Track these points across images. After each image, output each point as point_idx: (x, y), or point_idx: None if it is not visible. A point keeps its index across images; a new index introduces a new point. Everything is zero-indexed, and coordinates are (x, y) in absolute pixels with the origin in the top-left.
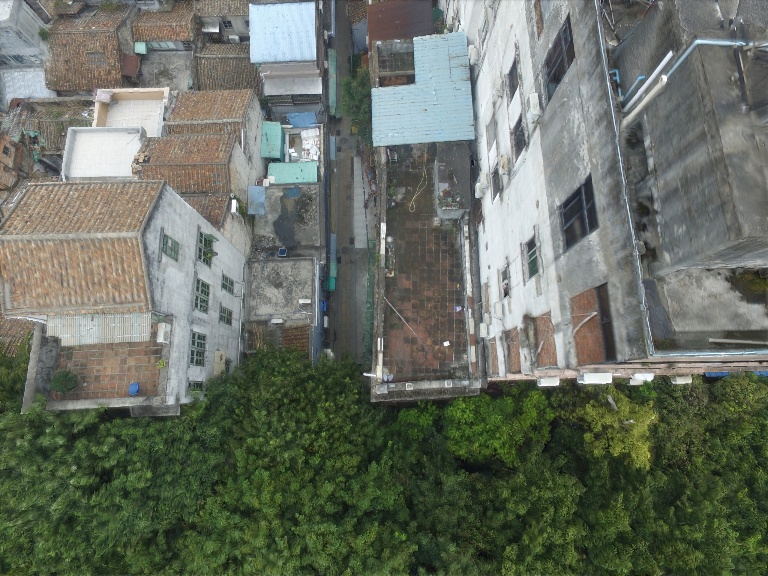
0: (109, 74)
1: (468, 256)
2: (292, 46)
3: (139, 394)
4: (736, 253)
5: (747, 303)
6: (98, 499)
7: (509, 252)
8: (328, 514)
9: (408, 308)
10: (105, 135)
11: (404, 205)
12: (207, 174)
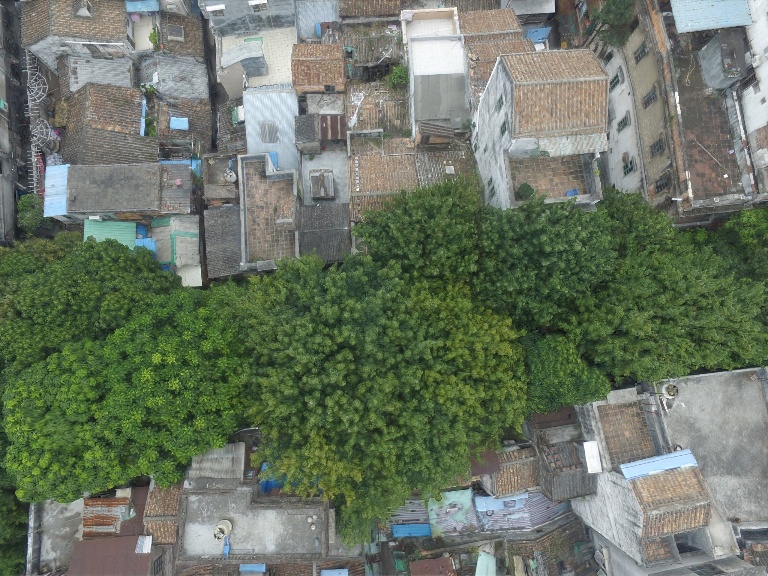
0: (390, 1)
1: (739, 113)
2: None
3: None
4: None
5: None
6: None
7: None
8: None
9: (696, 153)
10: (433, 43)
11: (682, 81)
12: None
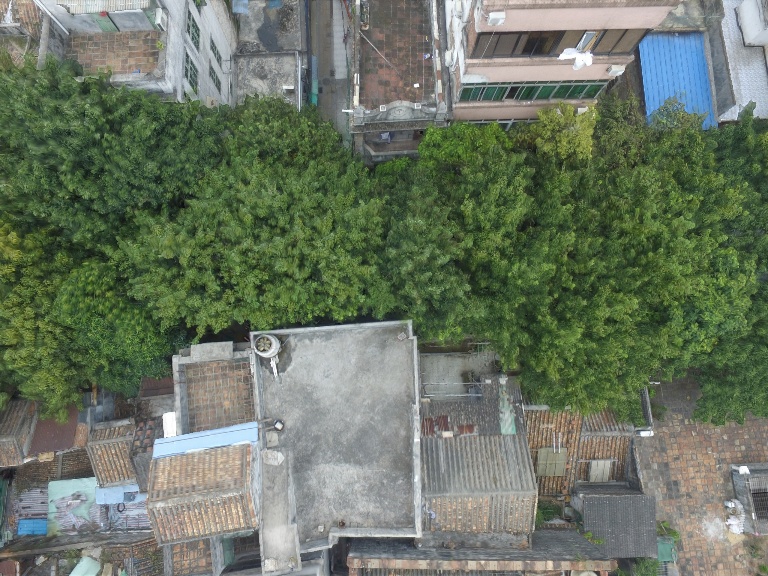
0: None
1: (435, 6)
2: None
3: None
4: None
5: None
6: (109, 139)
7: None
8: None
9: None
10: None
11: None
12: None
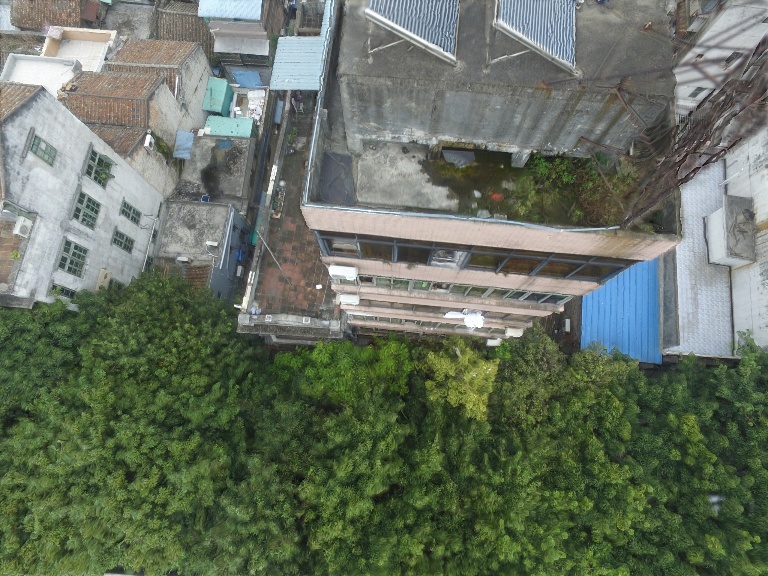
0: (69, 16)
1: None
2: (239, 5)
3: None
4: (368, 107)
5: (432, 184)
6: None
7: None
8: (164, 425)
9: (288, 249)
10: (43, 64)
11: (302, 153)
12: (127, 108)
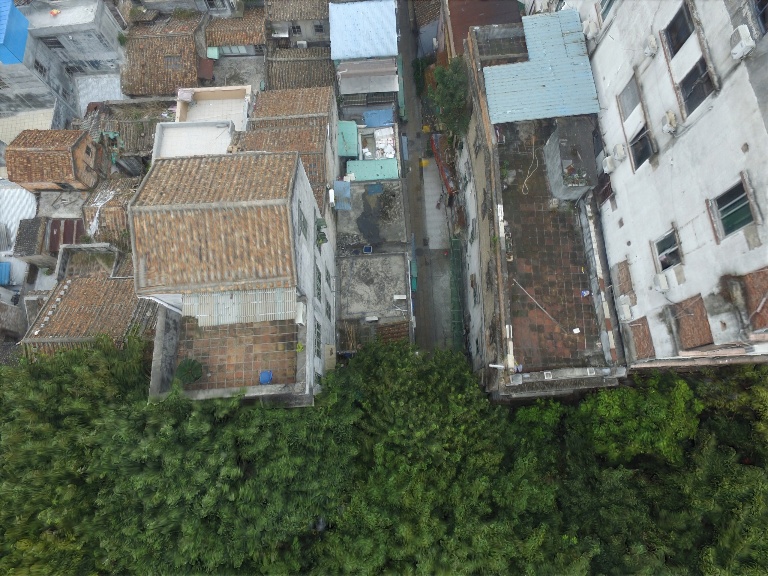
0: (185, 77)
1: (594, 237)
2: (373, 42)
3: (271, 383)
4: None
5: None
6: (244, 497)
7: (677, 216)
8: None
9: (531, 294)
10: (193, 130)
11: (516, 188)
12: None
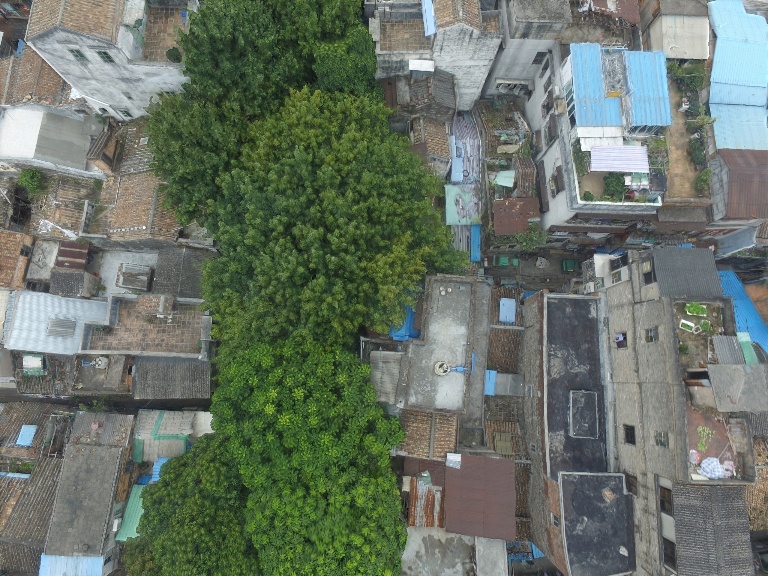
0: None
1: None
2: None
3: None
4: None
5: None
6: None
7: None
8: None
9: None
10: (0, 135)
11: None
12: None
